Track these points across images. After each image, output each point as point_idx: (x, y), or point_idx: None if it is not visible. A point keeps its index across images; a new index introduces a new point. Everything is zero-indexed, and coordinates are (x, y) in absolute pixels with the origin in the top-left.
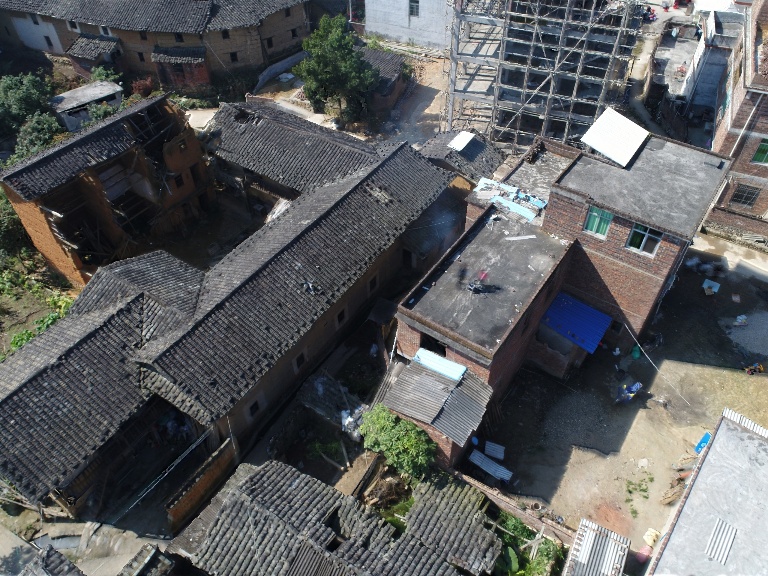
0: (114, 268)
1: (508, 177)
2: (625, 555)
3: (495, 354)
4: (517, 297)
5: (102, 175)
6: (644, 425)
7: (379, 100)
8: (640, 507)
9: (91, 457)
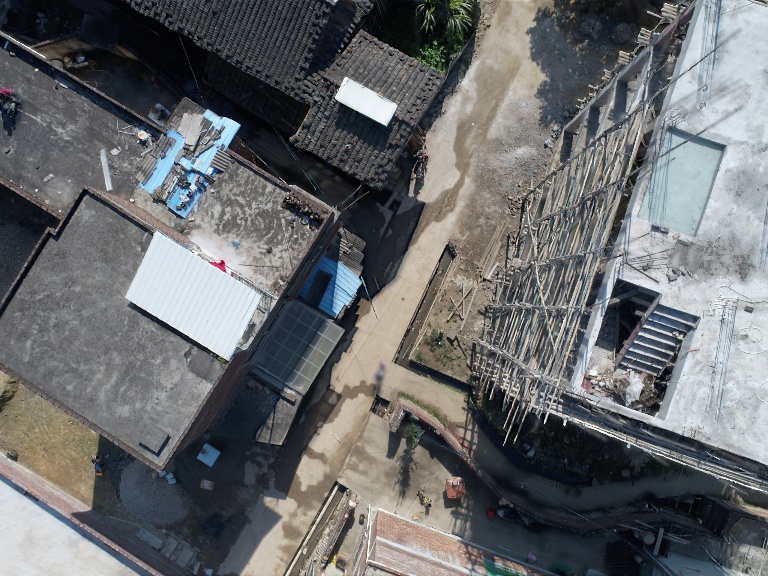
0: None
1: (244, 164)
2: None
3: None
4: None
5: None
6: None
7: None
8: None
9: None
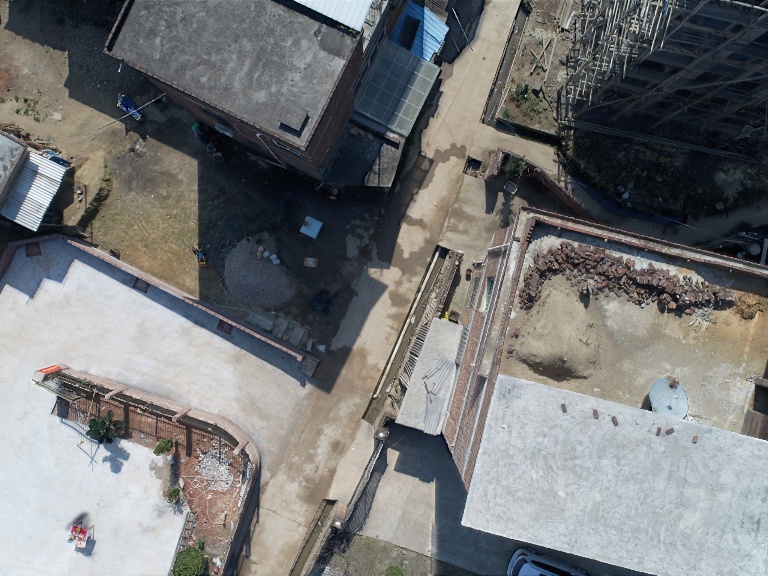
0: None
1: None
2: None
3: None
4: None
5: None
6: (103, 124)
7: None
8: (7, 105)
9: None
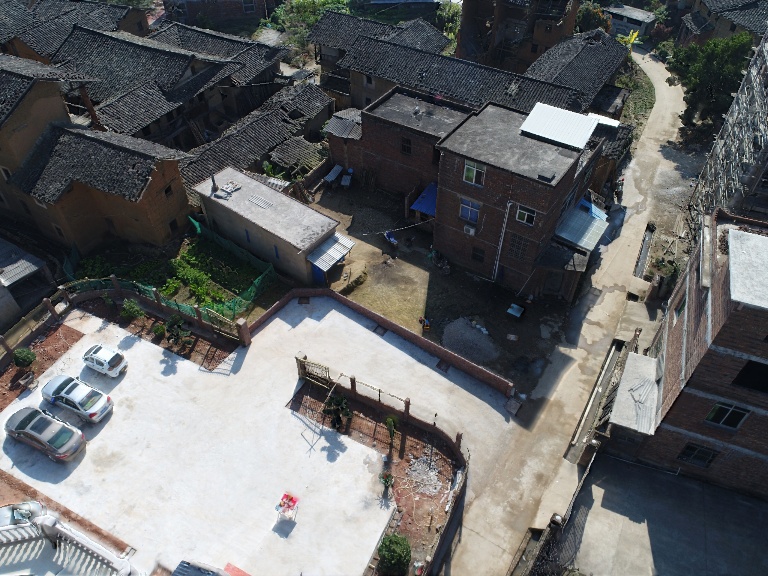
0: (423, 22)
1: None
2: None
3: (364, 114)
4: (412, 126)
5: (522, 22)
6: (368, 248)
7: (718, 127)
8: None
9: (331, 55)
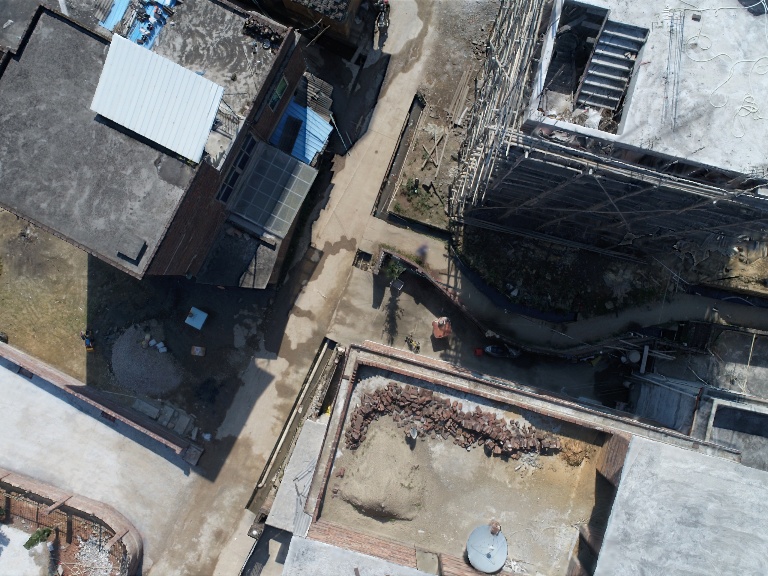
0: None
1: None
2: None
3: None
4: None
5: None
6: None
7: None
8: None
9: None
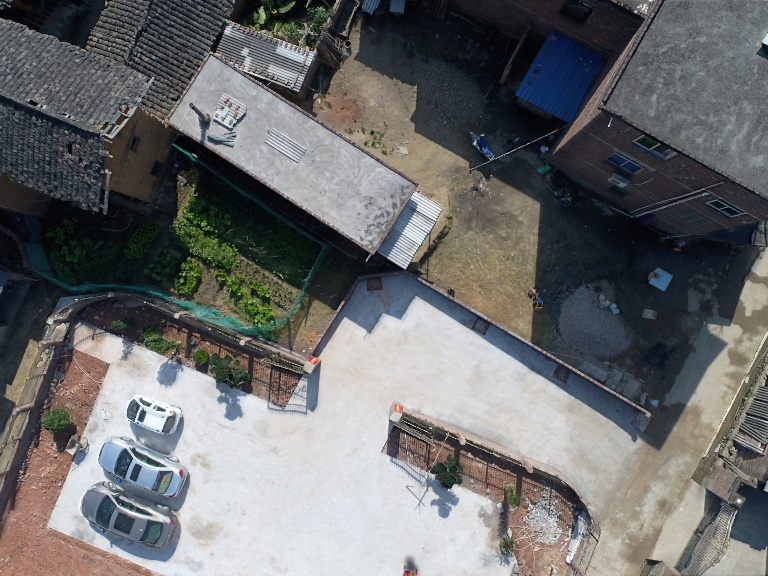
0: None
1: None
2: (285, 85)
3: None
4: None
5: None
6: (448, 161)
7: None
8: (355, 137)
9: None
